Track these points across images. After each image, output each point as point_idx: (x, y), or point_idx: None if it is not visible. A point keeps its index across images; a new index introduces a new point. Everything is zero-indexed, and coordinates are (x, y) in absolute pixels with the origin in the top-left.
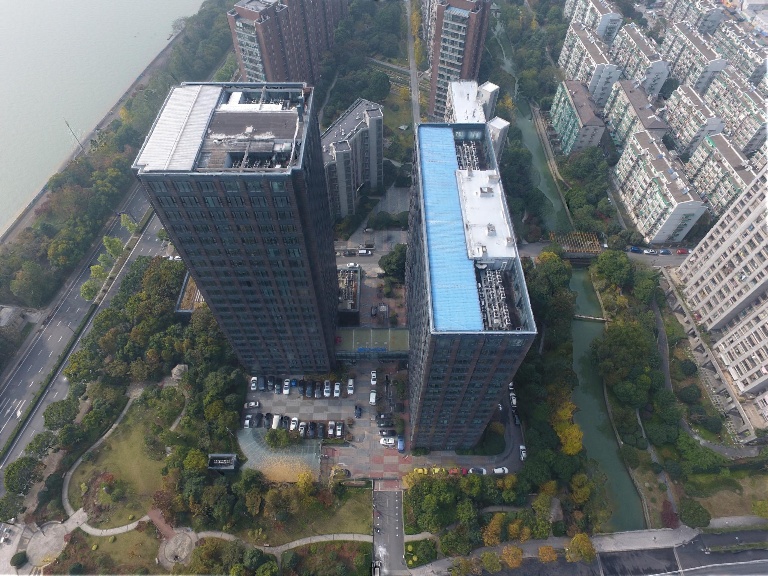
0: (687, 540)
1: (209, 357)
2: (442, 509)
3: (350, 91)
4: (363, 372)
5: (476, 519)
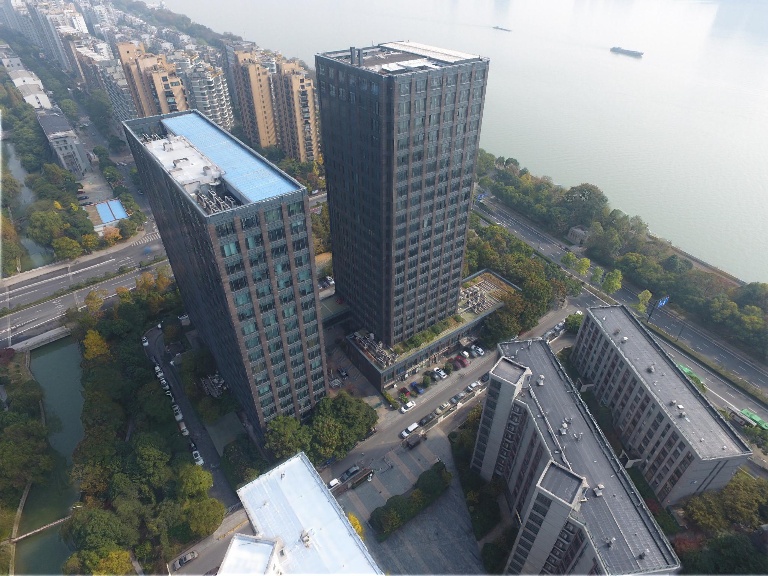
0: None
1: None
2: None
3: None
4: None
5: None
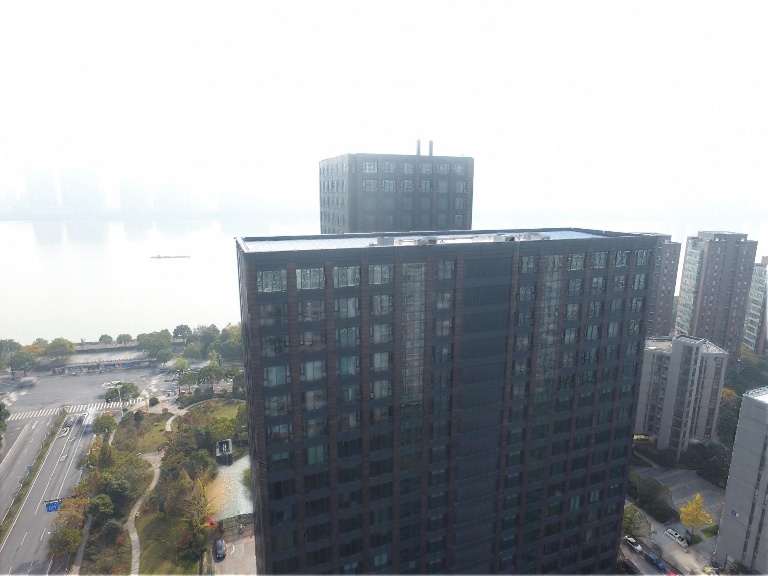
0: None
1: None
2: None
3: (764, 383)
4: None
5: None
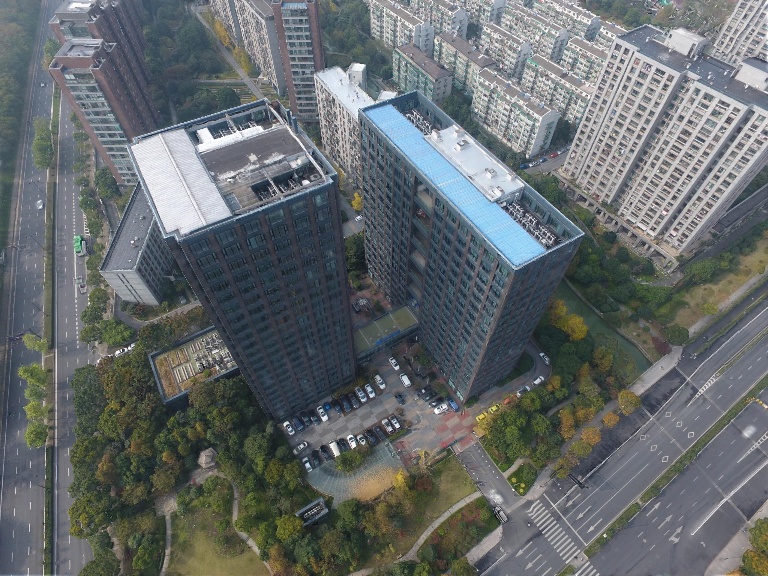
0: (679, 357)
1: (232, 427)
2: (521, 434)
3: None
4: (382, 364)
5: (551, 425)
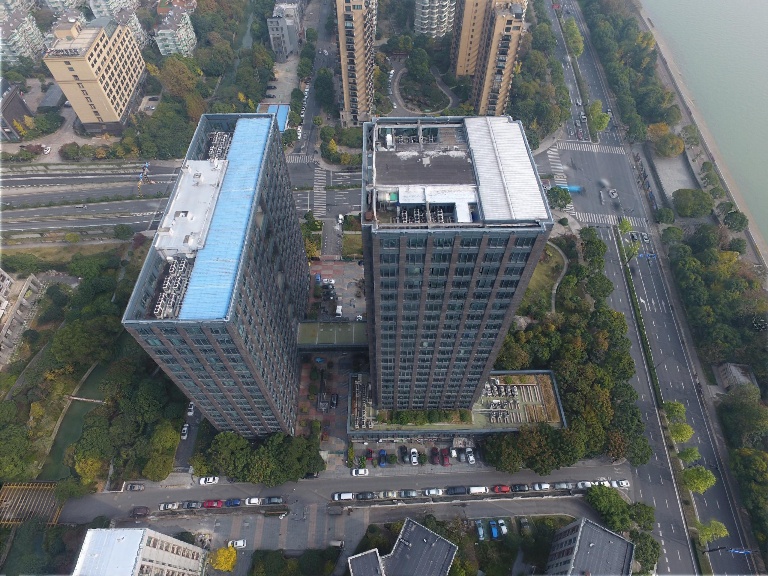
0: None
1: None
2: None
3: None
4: None
5: None
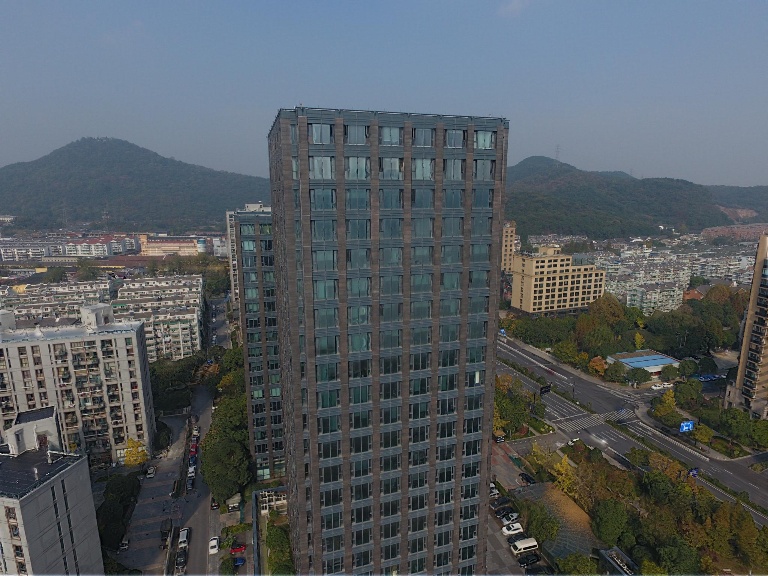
0: None
1: None
2: None
3: None
4: None
5: None
